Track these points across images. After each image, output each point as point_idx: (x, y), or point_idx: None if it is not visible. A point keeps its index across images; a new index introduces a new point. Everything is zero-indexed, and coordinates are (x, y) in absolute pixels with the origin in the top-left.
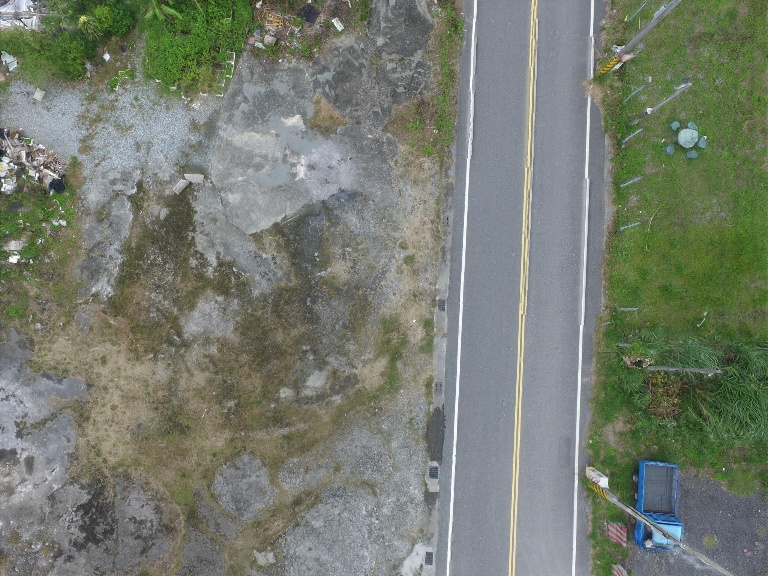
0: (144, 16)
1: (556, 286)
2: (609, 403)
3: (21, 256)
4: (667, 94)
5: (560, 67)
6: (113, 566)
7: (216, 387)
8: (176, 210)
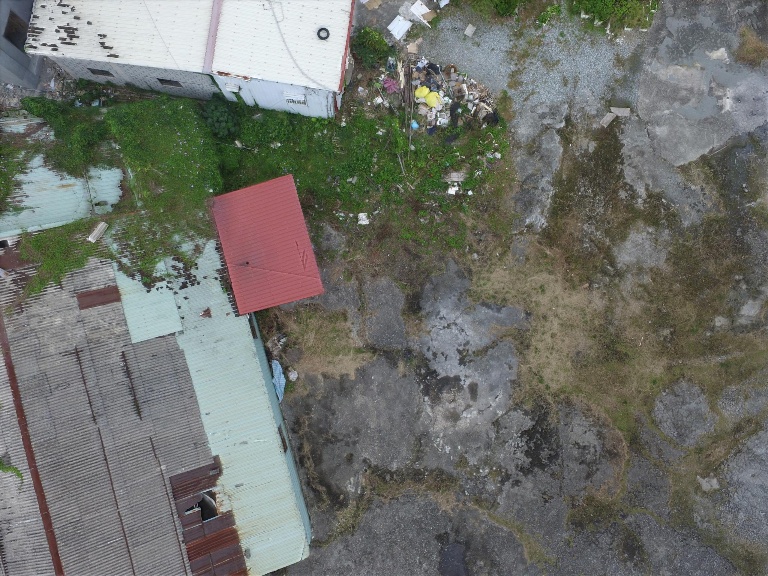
0: None
1: None
2: None
3: (463, 187)
4: None
5: None
6: (560, 490)
7: (652, 316)
8: (604, 143)
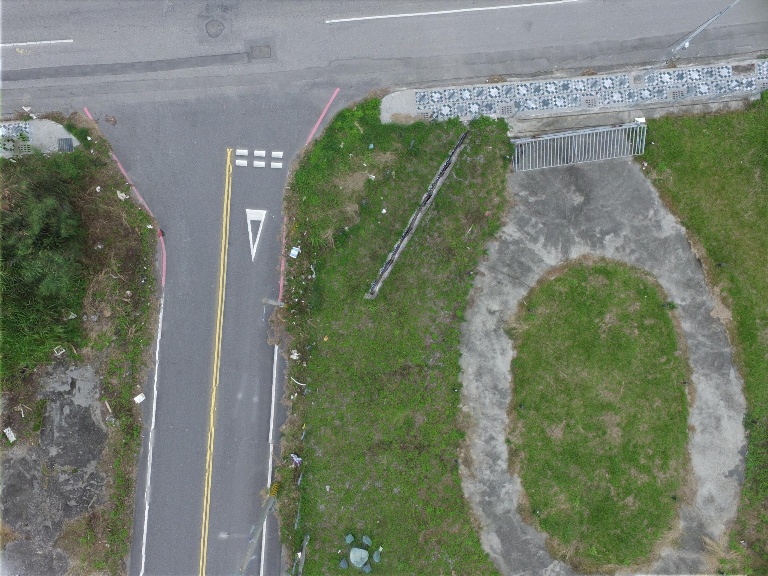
0: None
1: None
2: None
3: None
4: (344, 503)
5: (237, 476)
6: None
7: None
8: None
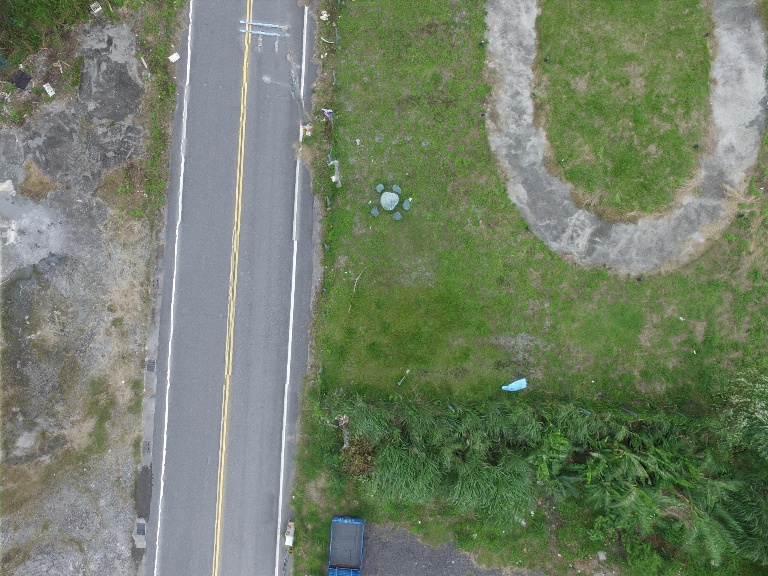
0: None
1: (262, 346)
2: (310, 460)
3: None
4: (374, 156)
5: (270, 130)
6: None
7: None
8: None
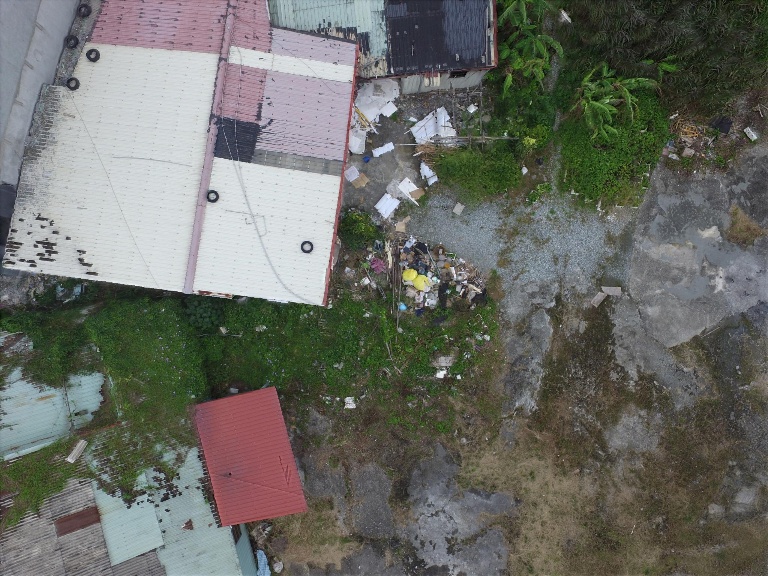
0: (591, 137)
1: None
2: None
3: (452, 372)
4: None
5: None
6: None
7: (644, 503)
8: (595, 323)
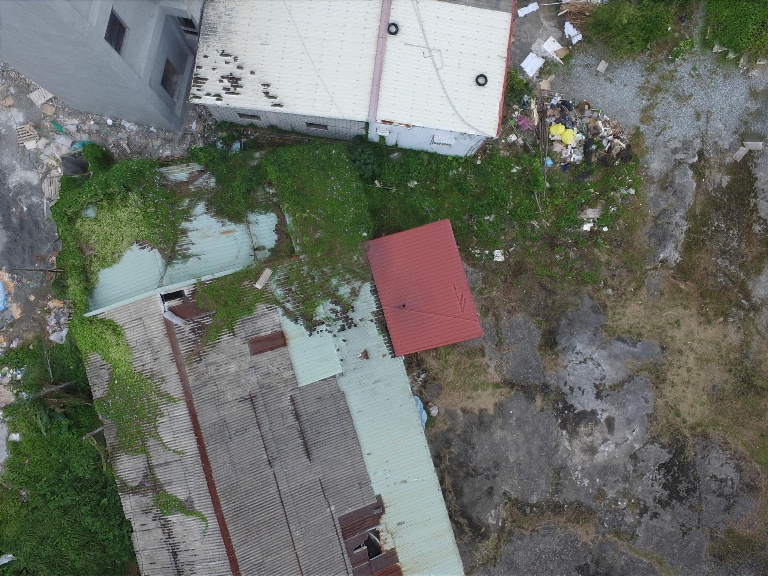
0: None
1: None
2: None
3: (600, 223)
4: None
5: None
6: (698, 522)
7: None
8: (736, 177)
